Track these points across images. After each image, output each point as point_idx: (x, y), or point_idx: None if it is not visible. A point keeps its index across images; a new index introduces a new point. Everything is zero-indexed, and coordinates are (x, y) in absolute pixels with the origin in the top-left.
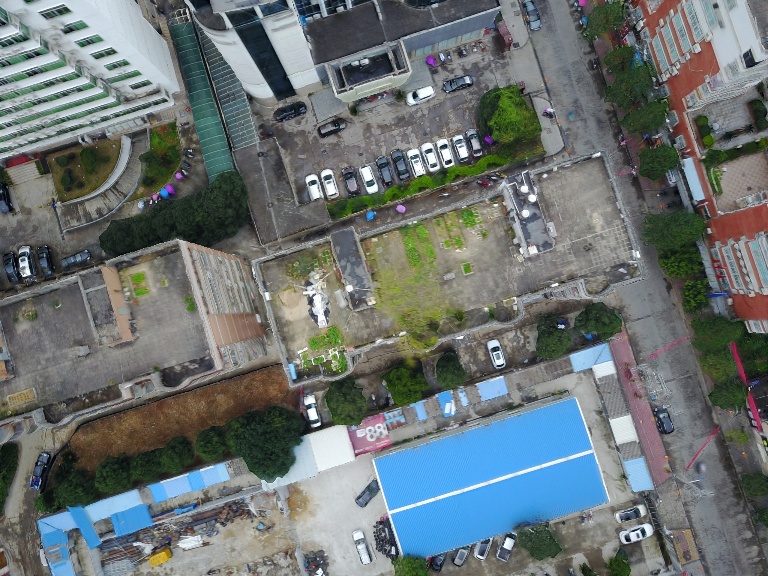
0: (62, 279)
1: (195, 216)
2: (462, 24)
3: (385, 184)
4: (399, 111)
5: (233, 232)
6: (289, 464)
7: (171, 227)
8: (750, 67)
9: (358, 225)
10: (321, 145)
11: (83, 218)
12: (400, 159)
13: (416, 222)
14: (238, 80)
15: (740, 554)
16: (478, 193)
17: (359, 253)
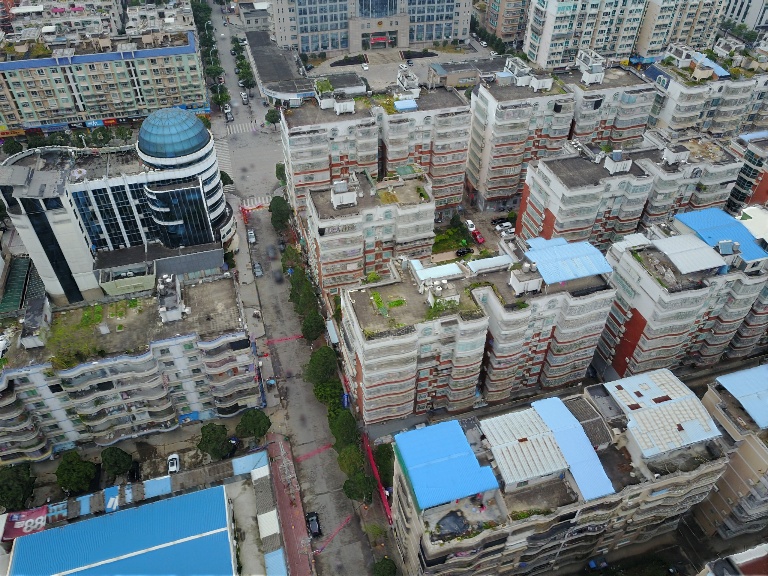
0: None
1: None
2: (198, 258)
3: None
4: None
5: None
6: None
7: None
8: (323, 236)
9: None
10: None
11: None
12: None
13: (96, 304)
14: (44, 286)
15: None
16: None
17: (43, 309)
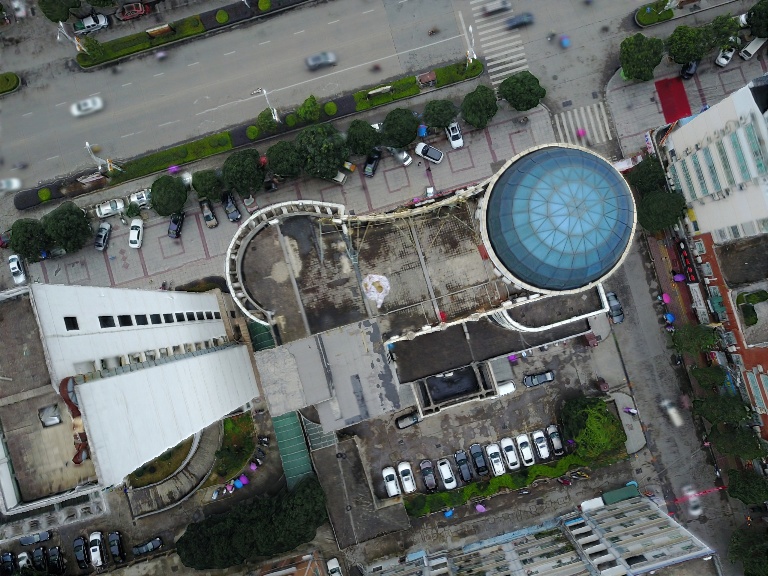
0: (133, 566)
1: (276, 534)
2: None
3: (464, 481)
4: (478, 403)
5: (312, 539)
6: None
7: (251, 544)
8: None
9: (435, 519)
10: (398, 435)
11: (155, 503)
12: (479, 456)
13: None
14: None
15: None
16: (558, 490)
17: None
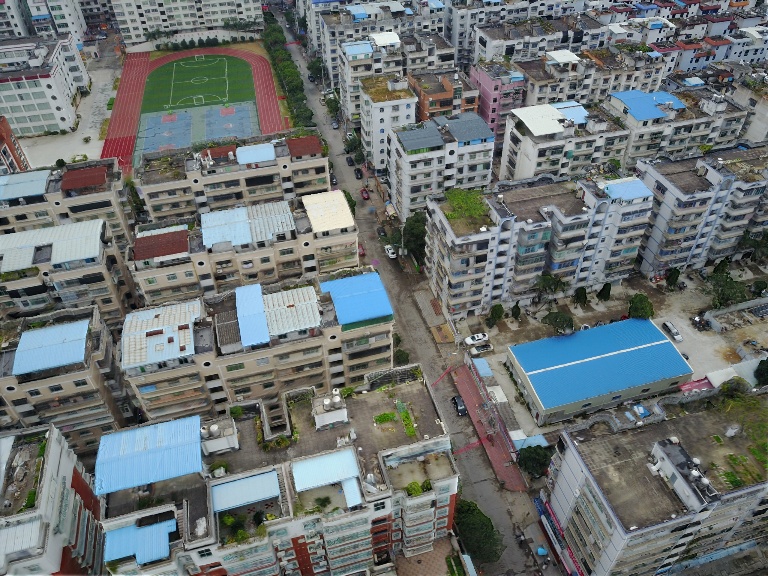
0: None
1: None
2: None
3: None
4: None
5: None
6: (761, 368)
7: None
8: None
9: None
10: None
11: None
12: None
13: None
14: None
15: (402, 330)
16: None
17: None
